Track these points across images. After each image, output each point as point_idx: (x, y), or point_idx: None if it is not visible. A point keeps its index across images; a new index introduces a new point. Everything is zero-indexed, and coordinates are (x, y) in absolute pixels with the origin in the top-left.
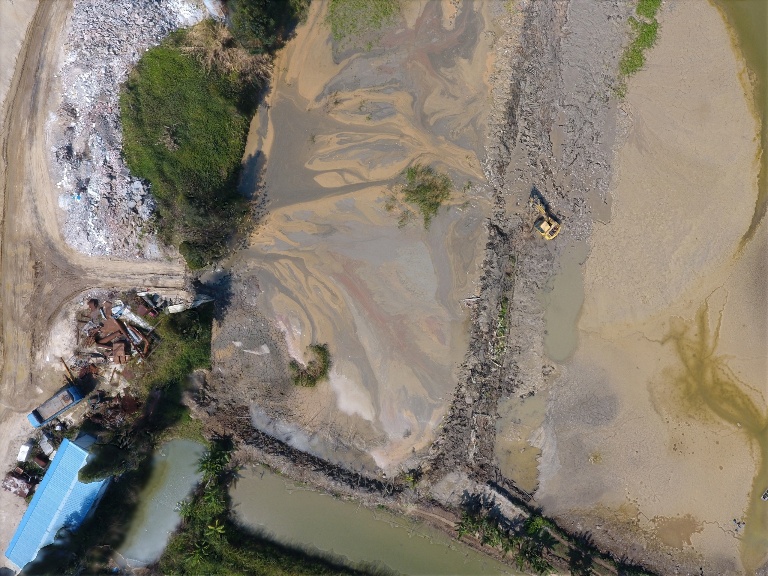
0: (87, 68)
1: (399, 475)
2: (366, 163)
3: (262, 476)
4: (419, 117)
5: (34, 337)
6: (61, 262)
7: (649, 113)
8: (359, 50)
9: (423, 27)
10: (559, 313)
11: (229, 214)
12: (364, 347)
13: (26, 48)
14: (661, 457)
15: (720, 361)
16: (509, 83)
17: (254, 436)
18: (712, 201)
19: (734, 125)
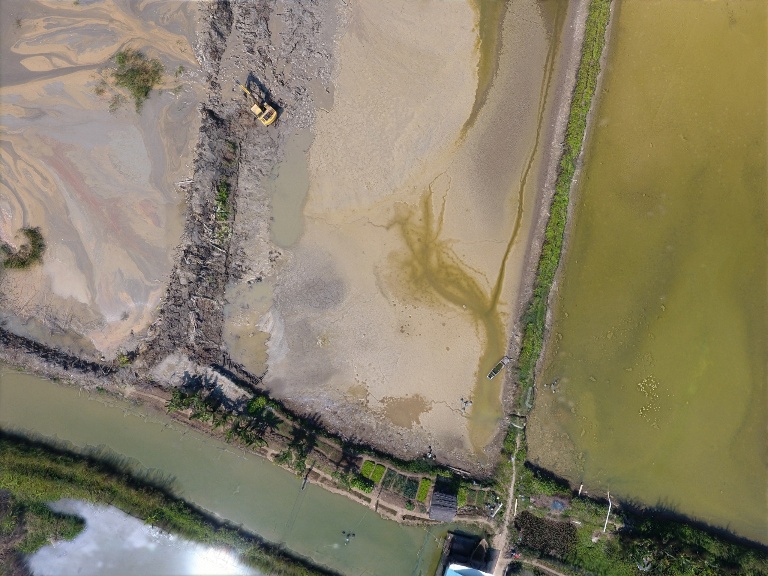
0: None
1: (118, 357)
2: (74, 47)
3: None
4: (128, 2)
5: None
6: None
7: (368, 3)
8: None
9: None
10: (285, 200)
11: None
12: (77, 230)
13: None
14: (389, 339)
15: (445, 245)
16: None
17: None
18: (433, 90)
19: (453, 16)
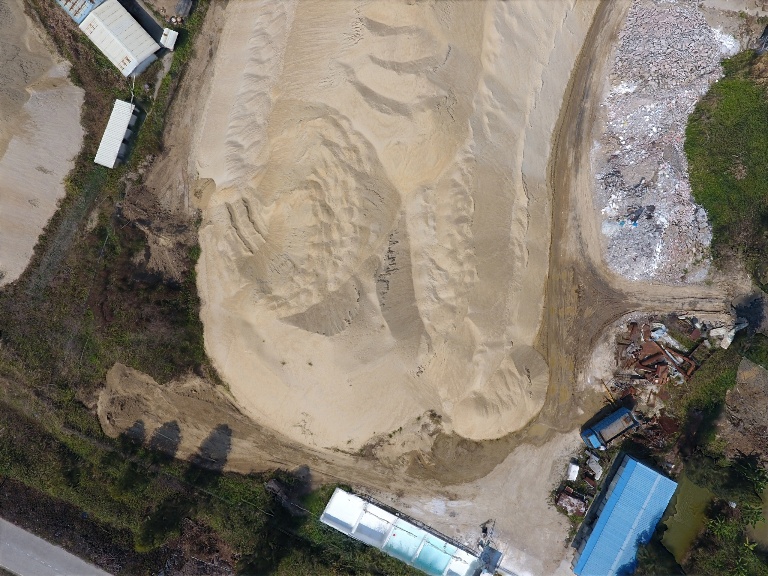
0: (654, 99)
1: None
2: None
3: None
4: None
5: (576, 359)
6: (602, 286)
7: None
8: None
9: None
10: None
11: None
12: None
13: (573, 78)
14: None
15: None
16: None
17: None
18: None
19: None
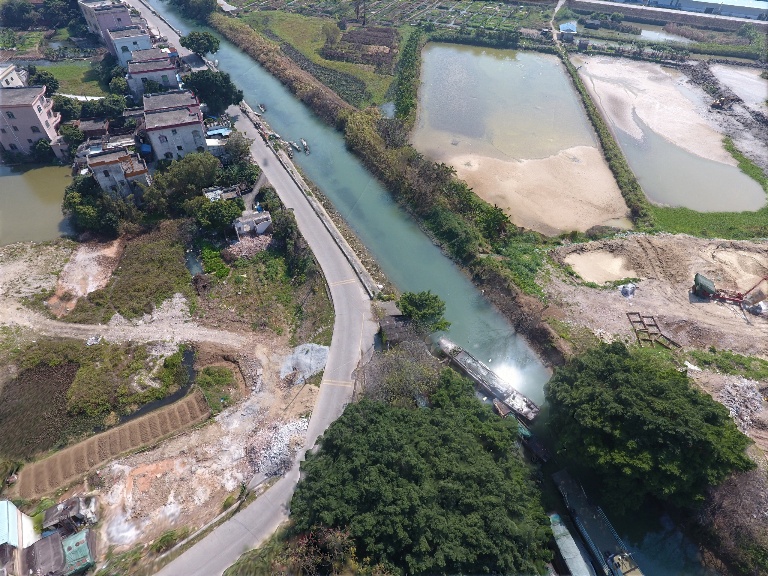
0: None
1: None
2: None
3: (757, 61)
4: None
5: None
6: None
7: None
8: None
9: None
10: None
11: None
12: None
13: None
14: None
15: None
16: None
17: (767, 67)
18: None
19: None
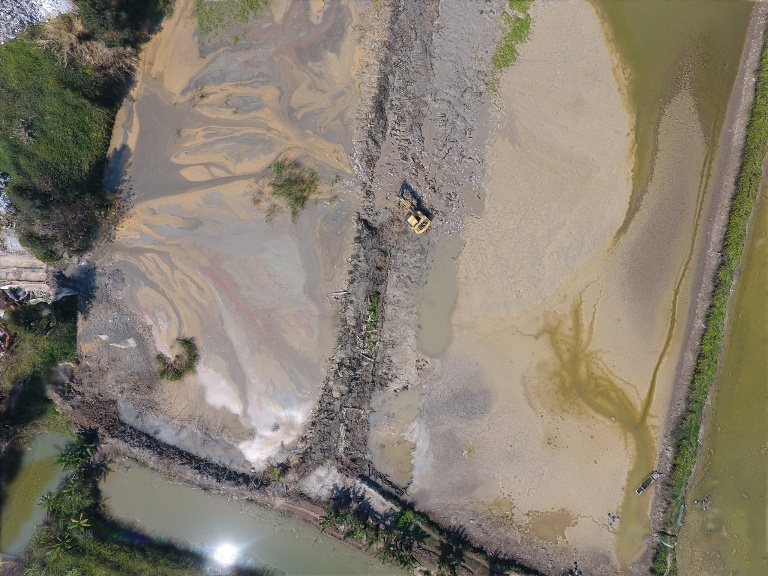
0: None
1: (268, 469)
2: (233, 157)
3: (127, 470)
4: (286, 111)
5: None
6: None
7: (522, 108)
8: (225, 44)
9: (290, 21)
10: (433, 307)
11: (83, 207)
12: (231, 341)
13: None
14: (535, 451)
15: (594, 355)
16: (376, 77)
17: (121, 430)
18: (586, 196)
19: (608, 120)
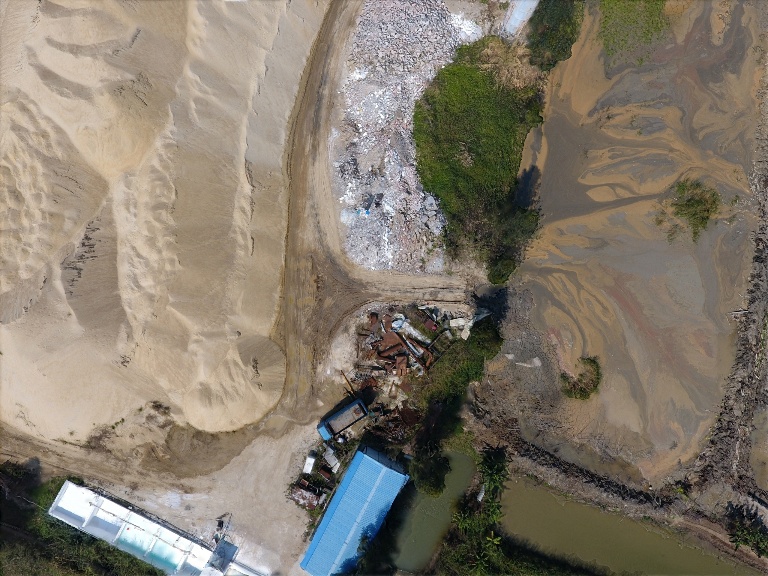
0: (382, 85)
1: (665, 486)
2: (637, 177)
3: (536, 488)
4: (688, 132)
5: (315, 350)
6: (342, 276)
7: None
8: (630, 65)
9: (692, 42)
10: None
11: None
12: (633, 360)
13: (310, 65)
14: None
15: None
16: None
17: (525, 448)
18: None
19: None
